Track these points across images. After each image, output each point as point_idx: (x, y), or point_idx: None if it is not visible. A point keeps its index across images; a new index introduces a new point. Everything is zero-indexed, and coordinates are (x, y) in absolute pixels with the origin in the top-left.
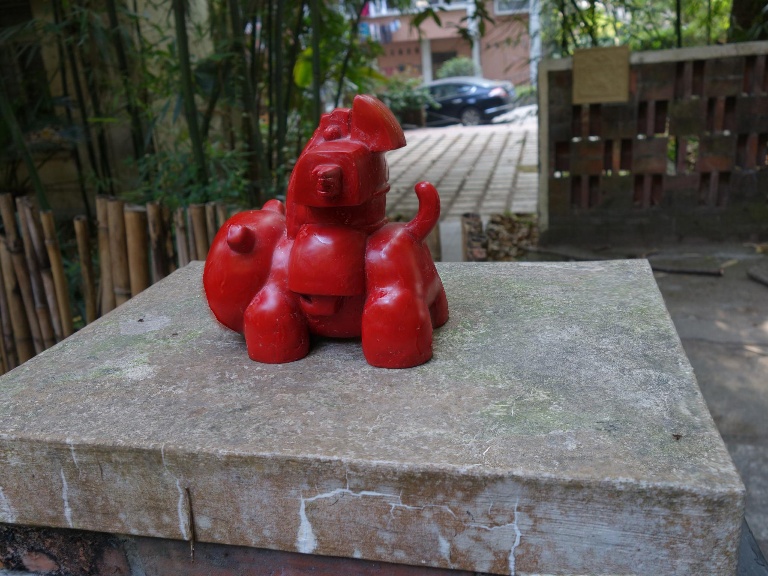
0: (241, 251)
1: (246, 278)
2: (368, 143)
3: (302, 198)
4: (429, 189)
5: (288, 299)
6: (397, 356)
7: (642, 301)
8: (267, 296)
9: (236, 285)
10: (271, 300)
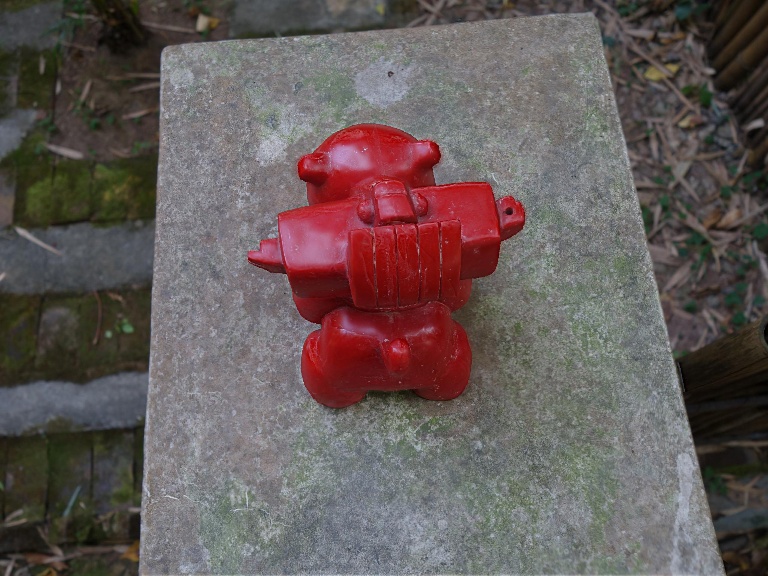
0: None
1: (312, 195)
2: None
3: None
4: (392, 358)
5: None
6: None
7: None
8: None
9: None
10: None
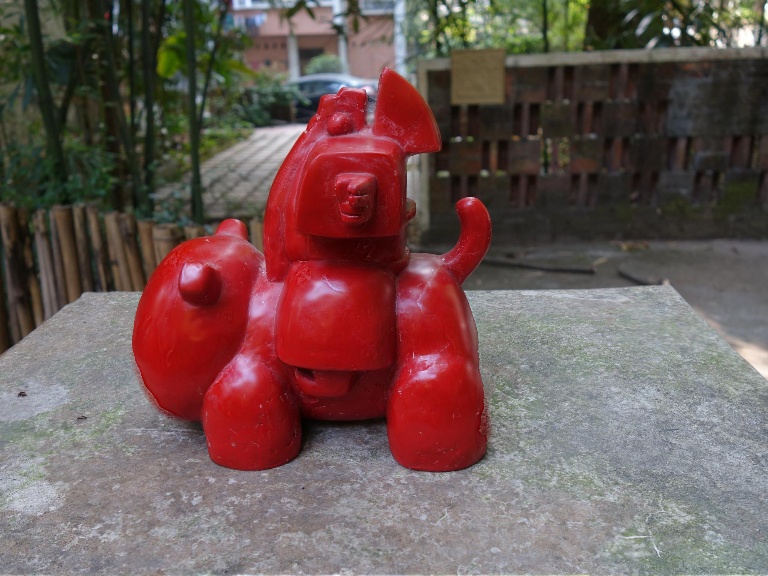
0: (201, 303)
1: (208, 343)
2: (402, 140)
3: (311, 224)
4: (479, 208)
5: (275, 373)
6: (448, 455)
7: (706, 345)
8: (243, 370)
9: (192, 354)
10: (250, 376)
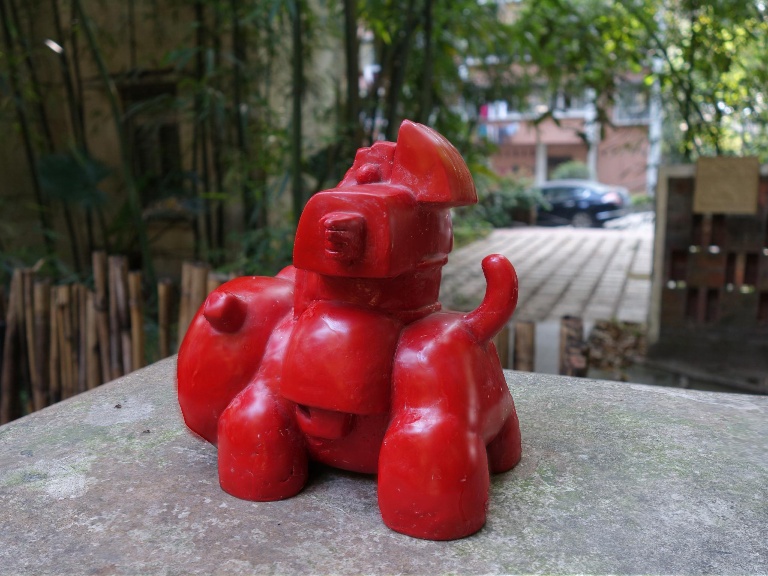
0: (223, 330)
1: (226, 369)
2: (415, 189)
3: (306, 260)
4: (503, 265)
5: (280, 406)
6: (426, 520)
7: None
8: (251, 399)
9: (212, 377)
10: (255, 405)
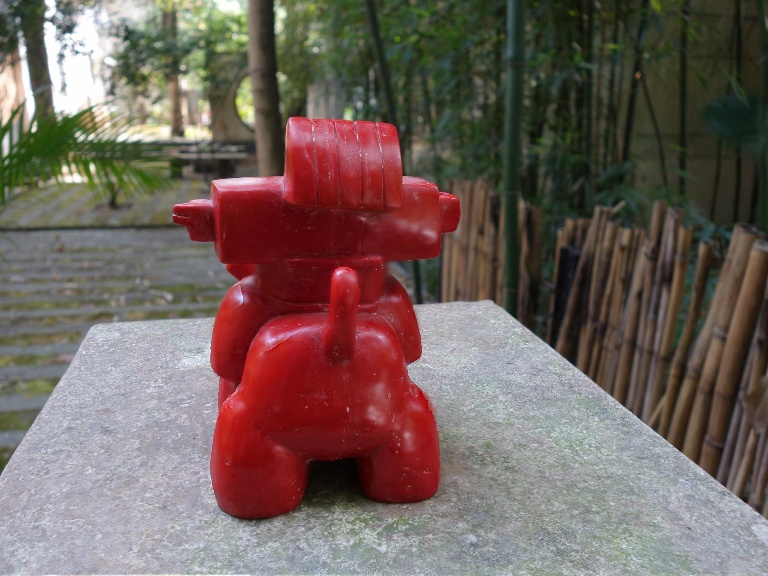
0: None
1: None
2: (285, 187)
3: None
4: (336, 280)
5: None
6: None
7: None
8: None
9: None
10: None
